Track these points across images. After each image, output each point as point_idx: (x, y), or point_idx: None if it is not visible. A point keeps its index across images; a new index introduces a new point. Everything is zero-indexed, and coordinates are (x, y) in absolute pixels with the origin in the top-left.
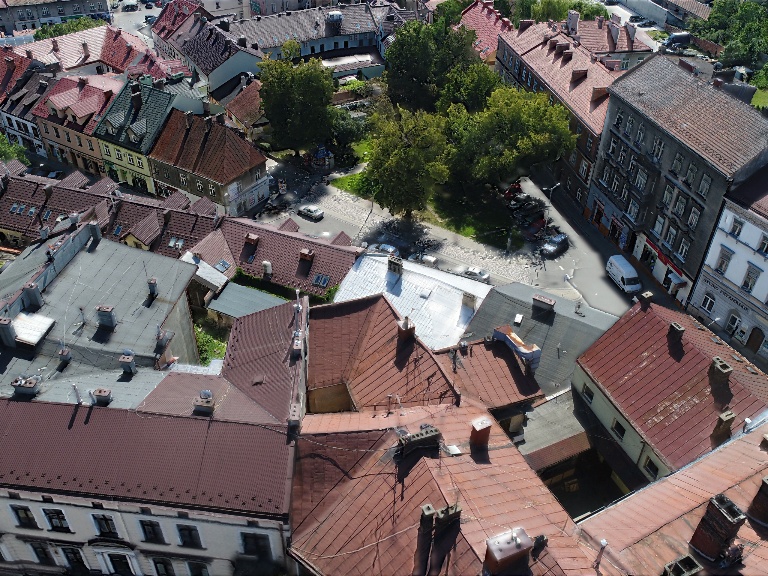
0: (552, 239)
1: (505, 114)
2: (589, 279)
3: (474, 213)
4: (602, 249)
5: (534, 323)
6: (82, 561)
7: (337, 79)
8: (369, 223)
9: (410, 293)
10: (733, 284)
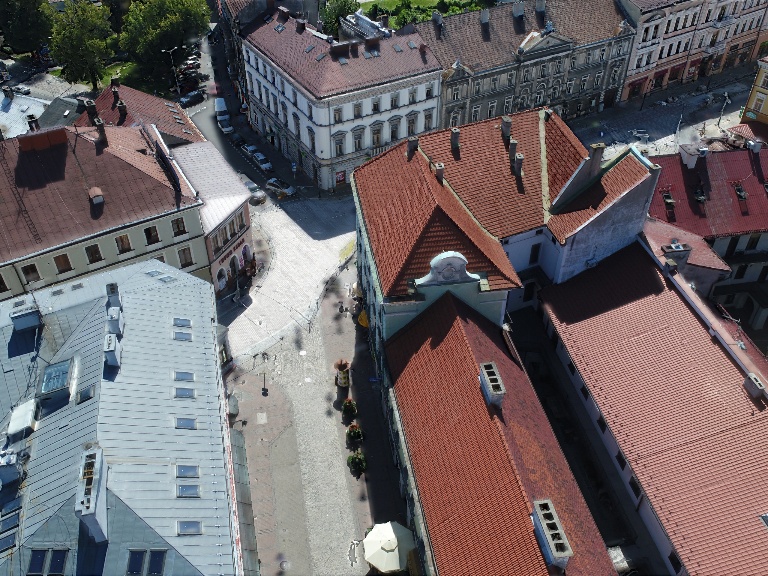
0: (187, 94)
1: (152, 2)
2: (201, 117)
3: (149, 85)
4: (226, 100)
5: (76, 114)
6: None
7: (90, 1)
8: (64, 95)
9: (15, 110)
10: (257, 99)
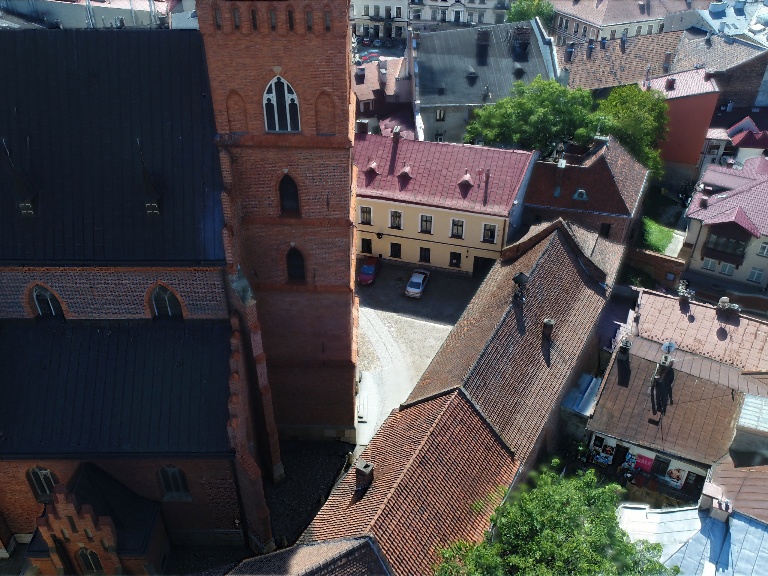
0: None
1: None
2: None
3: None
4: None
5: None
6: (445, 18)
7: None
8: None
9: None
10: None
